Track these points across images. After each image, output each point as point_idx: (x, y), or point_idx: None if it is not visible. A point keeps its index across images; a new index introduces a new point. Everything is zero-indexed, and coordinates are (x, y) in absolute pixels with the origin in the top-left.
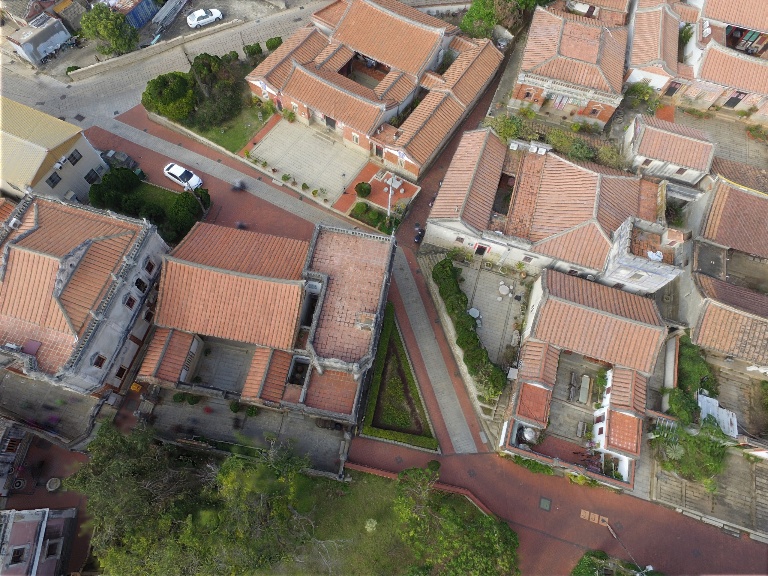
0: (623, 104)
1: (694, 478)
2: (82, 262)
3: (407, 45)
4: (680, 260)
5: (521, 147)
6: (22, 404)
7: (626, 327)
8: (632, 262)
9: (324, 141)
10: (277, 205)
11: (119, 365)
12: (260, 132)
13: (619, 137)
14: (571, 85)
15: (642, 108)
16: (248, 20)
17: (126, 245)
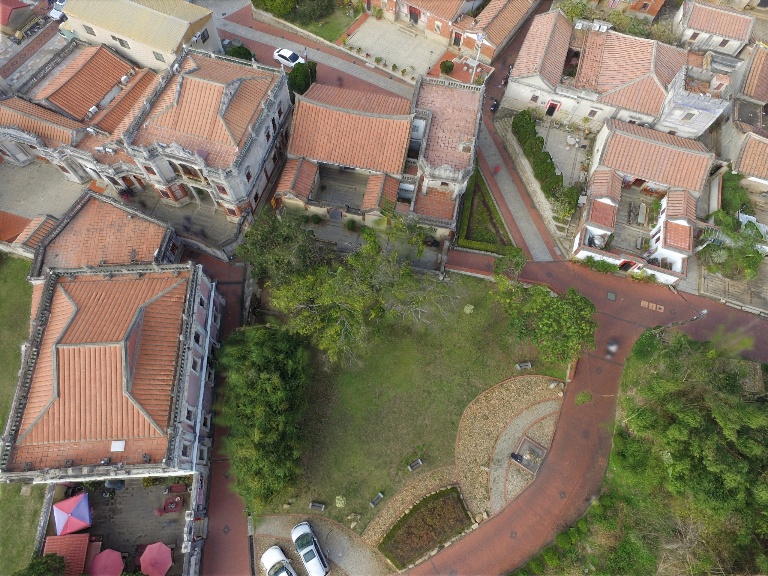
0: (669, 2)
1: (735, 277)
2: (237, 94)
3: None
4: (726, 96)
5: (585, 27)
6: (173, 226)
7: (680, 155)
8: (686, 99)
9: (407, 34)
10: (371, 82)
11: (257, 189)
12: (352, 27)
13: None
14: None
15: None
16: None
17: (267, 86)
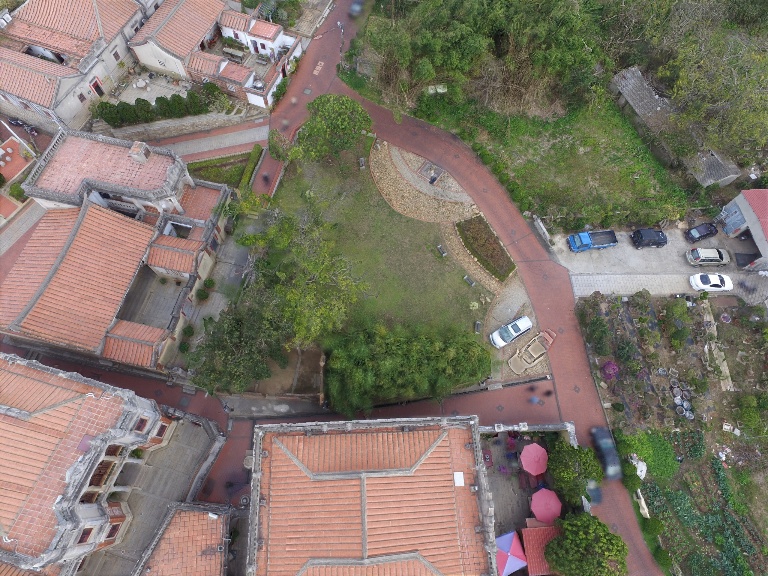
0: None
1: (300, 12)
2: None
3: None
4: None
5: None
6: None
7: (189, 3)
8: None
9: None
10: None
11: None
12: None
13: None
14: None
15: None
16: None
17: None
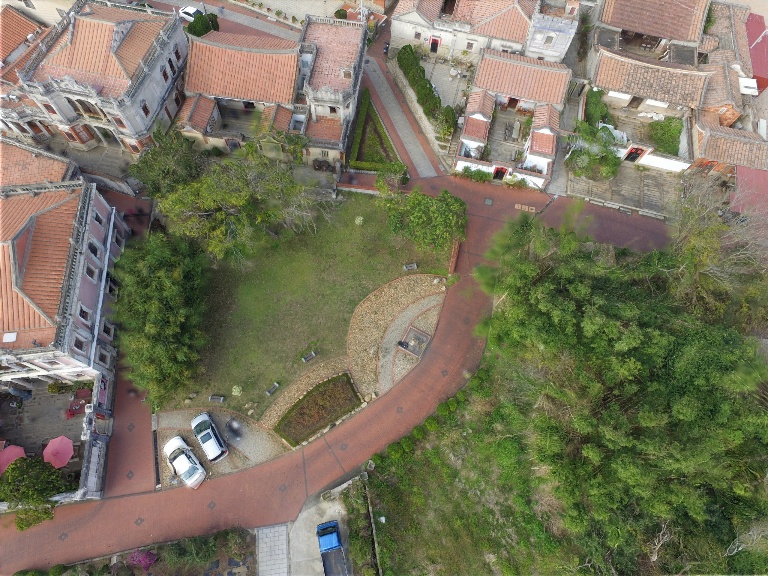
0: None
1: (597, 178)
2: (129, 34)
3: None
4: (577, 18)
5: None
6: None
7: (542, 73)
8: (543, 22)
9: None
10: (273, 34)
11: (158, 126)
12: None
13: None
14: None
15: None
16: None
17: (161, 28)
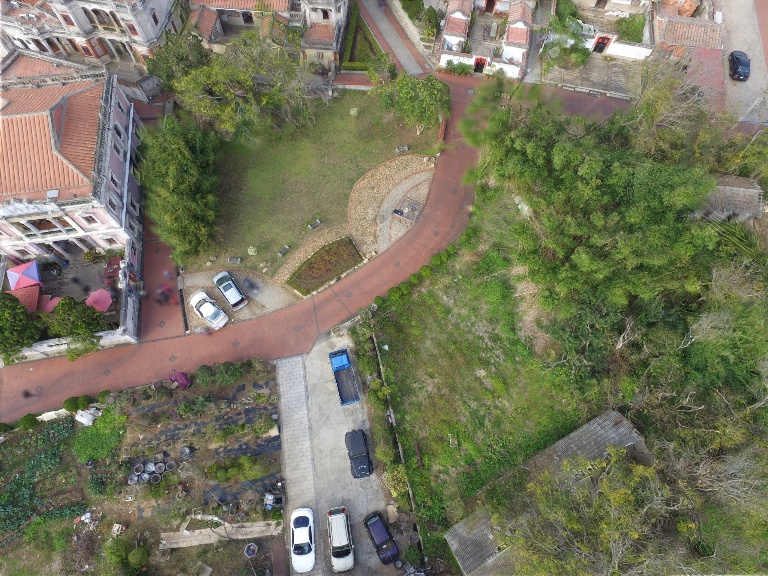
0: None
1: (568, 67)
2: None
3: None
4: None
5: None
6: None
7: None
8: None
9: None
10: None
11: None
12: None
13: None
14: None
15: None
16: None
17: None
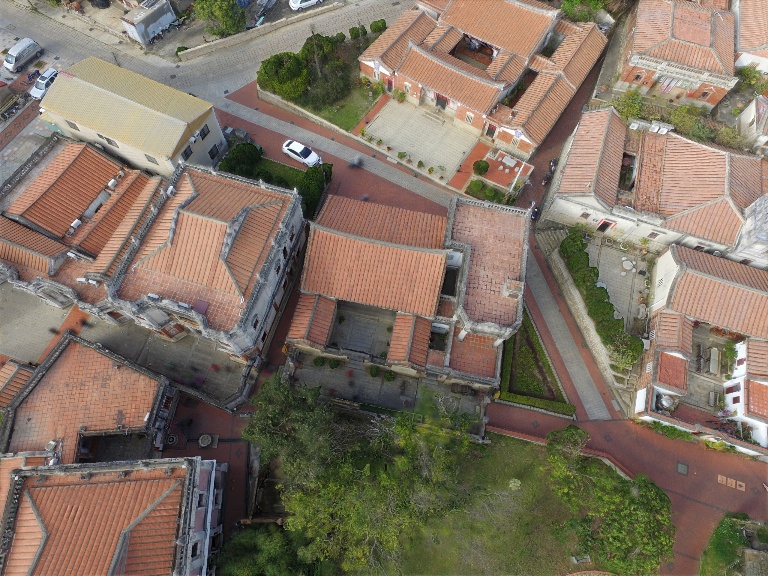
0: None
1: None
2: (242, 228)
3: (517, 27)
4: None
5: (641, 127)
6: (167, 365)
7: (762, 300)
8: None
9: (433, 121)
10: (393, 182)
11: (265, 329)
12: (371, 111)
13: (727, 120)
14: (686, 67)
15: (747, 92)
16: (347, 3)
17: (277, 213)
